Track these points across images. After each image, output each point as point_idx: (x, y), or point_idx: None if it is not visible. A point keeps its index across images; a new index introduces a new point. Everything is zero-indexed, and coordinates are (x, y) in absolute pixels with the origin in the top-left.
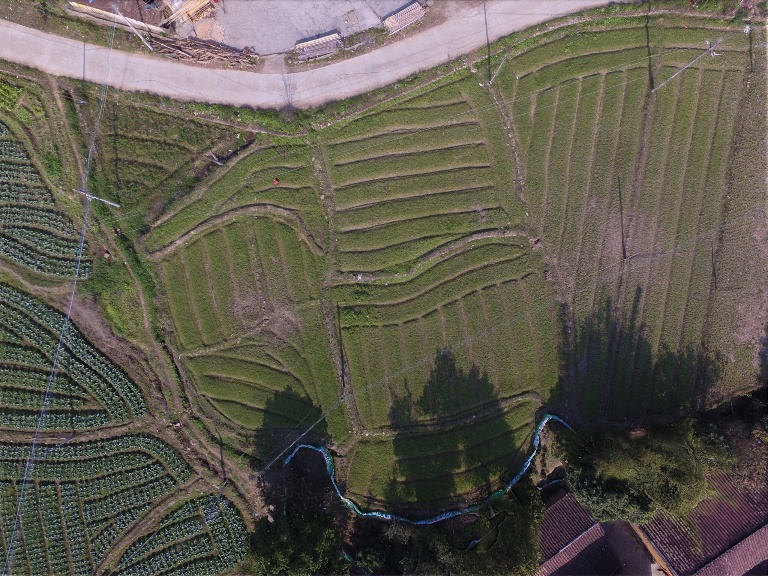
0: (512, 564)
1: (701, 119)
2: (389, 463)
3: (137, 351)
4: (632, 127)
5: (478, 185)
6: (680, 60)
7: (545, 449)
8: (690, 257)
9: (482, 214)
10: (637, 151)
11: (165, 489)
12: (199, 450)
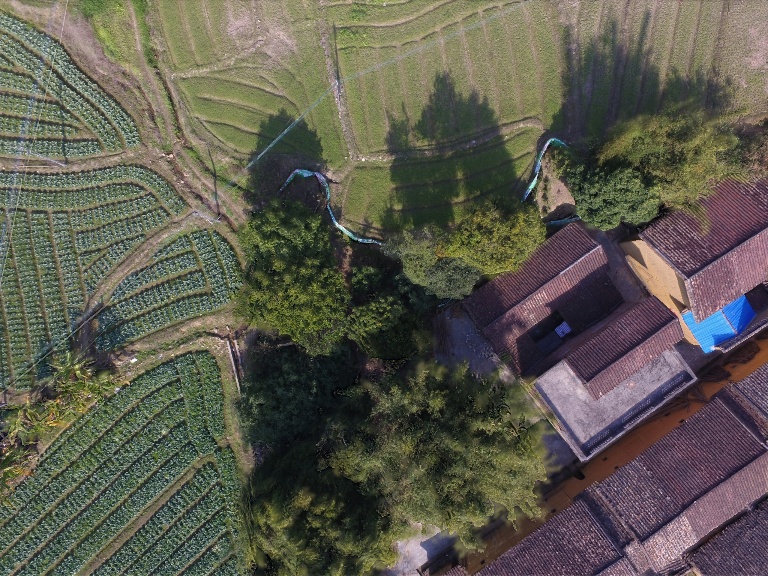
0: (510, 216)
1: None
2: (386, 190)
3: (130, 78)
4: None
5: None
6: None
7: (547, 179)
8: None
9: None
10: None
11: (158, 220)
12: (192, 182)
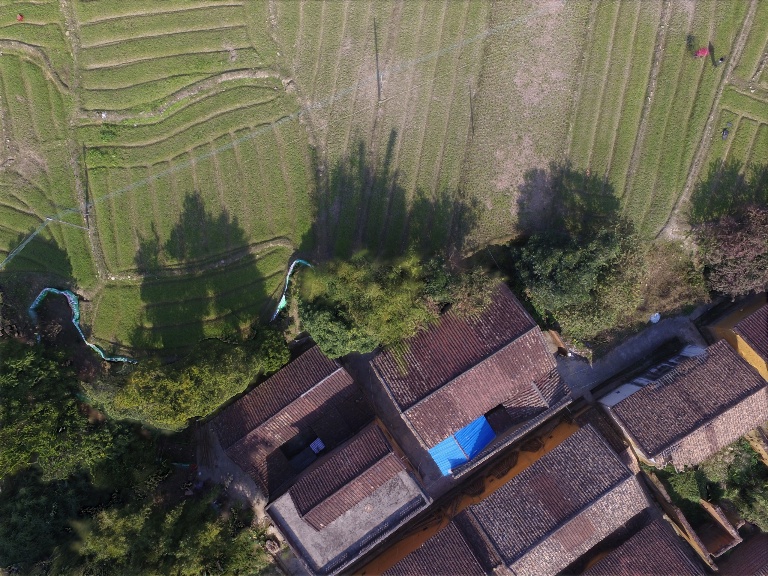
0: (186, 368)
1: None
2: (136, 308)
3: None
4: None
5: (229, 24)
6: None
7: None
8: (447, 101)
9: (233, 54)
10: None
11: None
12: None
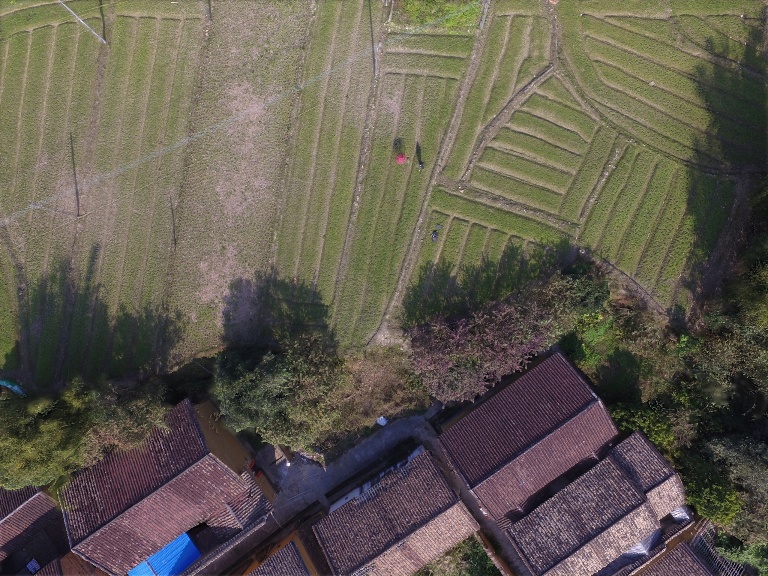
0: None
1: (157, 70)
2: None
3: None
4: (84, 80)
5: None
6: (134, 9)
7: None
8: (148, 214)
9: None
10: (91, 105)
11: None
12: None
